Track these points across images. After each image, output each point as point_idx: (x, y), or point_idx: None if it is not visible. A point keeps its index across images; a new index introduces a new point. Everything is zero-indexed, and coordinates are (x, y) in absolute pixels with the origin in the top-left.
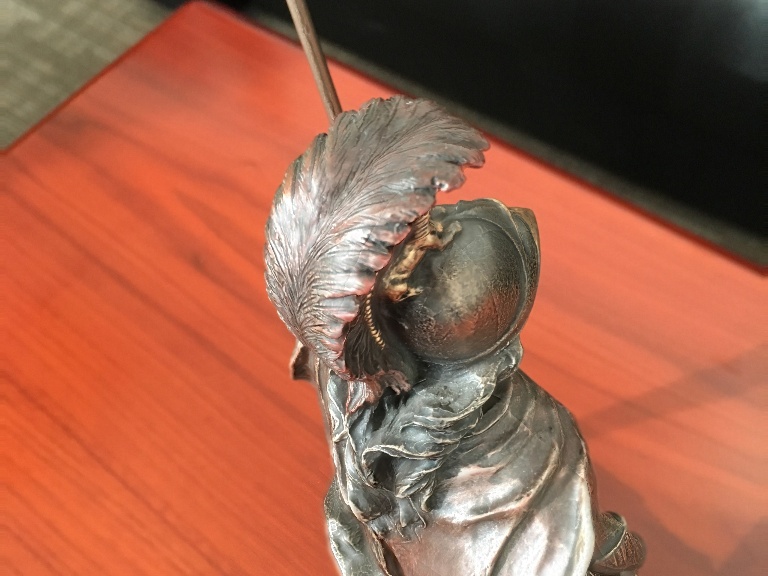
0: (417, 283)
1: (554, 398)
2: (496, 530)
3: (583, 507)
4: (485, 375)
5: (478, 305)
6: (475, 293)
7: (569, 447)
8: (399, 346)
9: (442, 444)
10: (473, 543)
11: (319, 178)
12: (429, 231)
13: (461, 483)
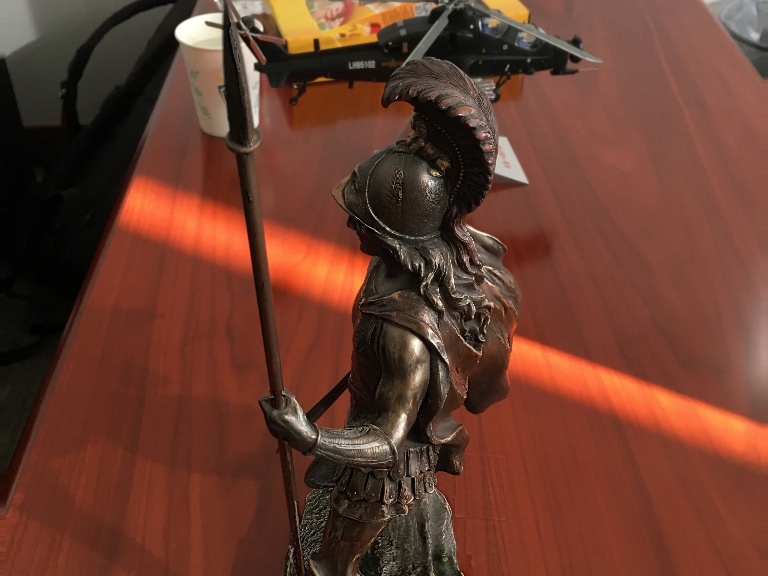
0: None
1: None
2: None
3: None
4: None
5: None
6: None
7: None
8: None
9: None
10: None
11: (459, 95)
12: None
13: None
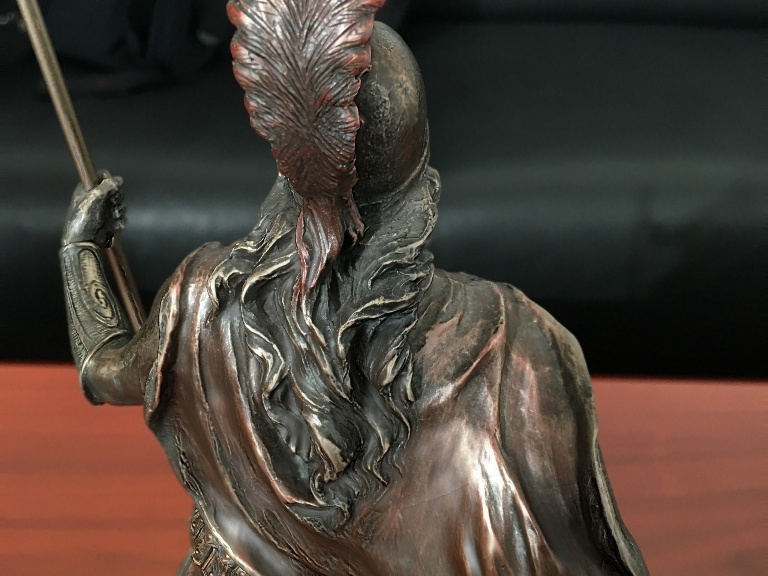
0: None
1: None
2: (486, 383)
3: (546, 321)
4: (423, 198)
5: (416, 82)
6: (411, 68)
7: None
8: None
9: (416, 281)
10: (469, 416)
11: None
12: None
13: (432, 351)
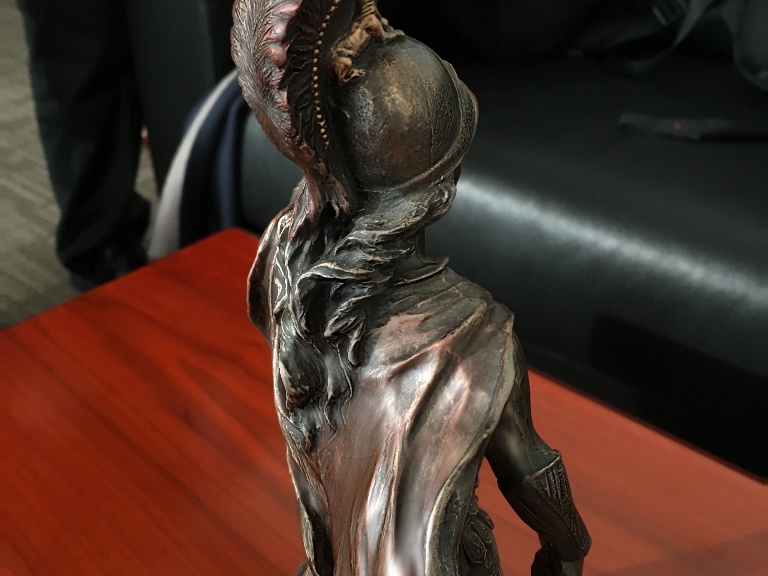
0: (361, 67)
1: None
2: (419, 379)
3: (506, 353)
4: (418, 201)
5: (413, 97)
6: (411, 84)
7: (498, 312)
8: (342, 156)
9: (372, 263)
10: (396, 399)
11: None
12: (374, 10)
13: (390, 333)
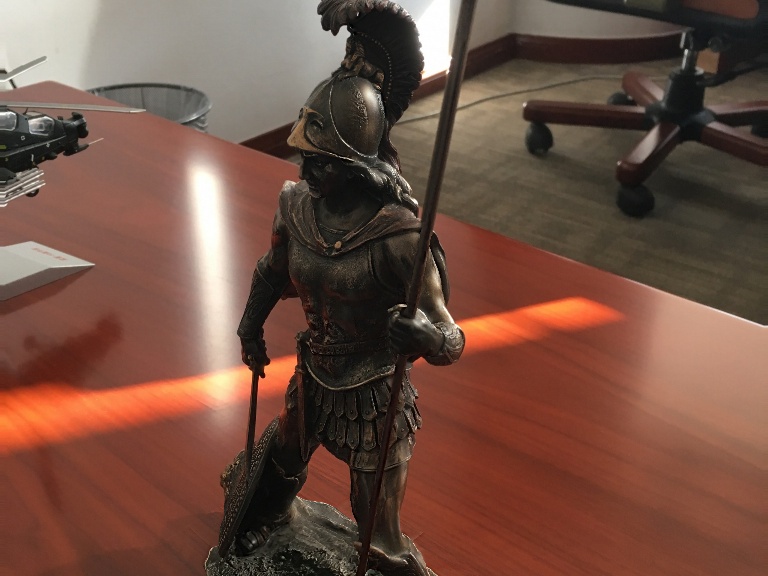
0: None
1: (287, 224)
2: None
3: (287, 185)
4: None
5: None
6: None
7: None
8: None
9: None
10: None
11: None
12: None
13: None
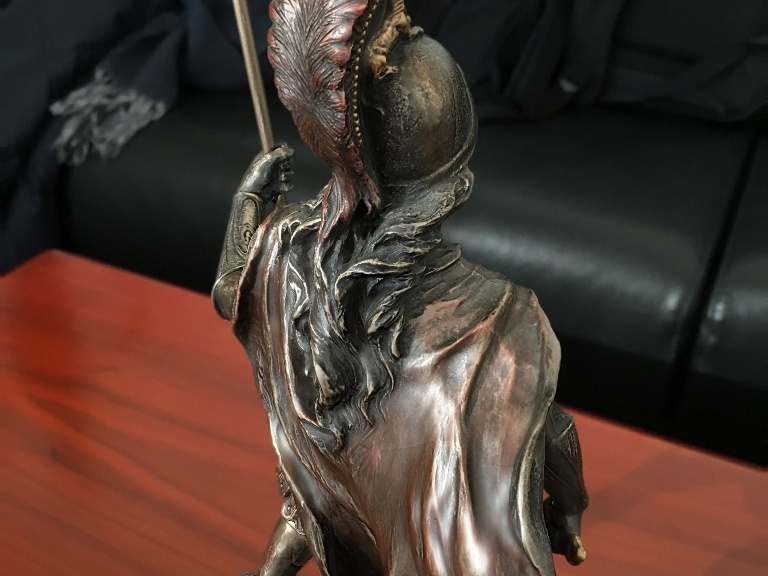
0: (393, 64)
1: None
2: (466, 361)
3: (543, 325)
4: (445, 191)
5: (443, 91)
6: (440, 78)
7: (519, 290)
8: (371, 153)
9: (413, 255)
10: (444, 384)
11: None
12: None
13: (427, 321)
